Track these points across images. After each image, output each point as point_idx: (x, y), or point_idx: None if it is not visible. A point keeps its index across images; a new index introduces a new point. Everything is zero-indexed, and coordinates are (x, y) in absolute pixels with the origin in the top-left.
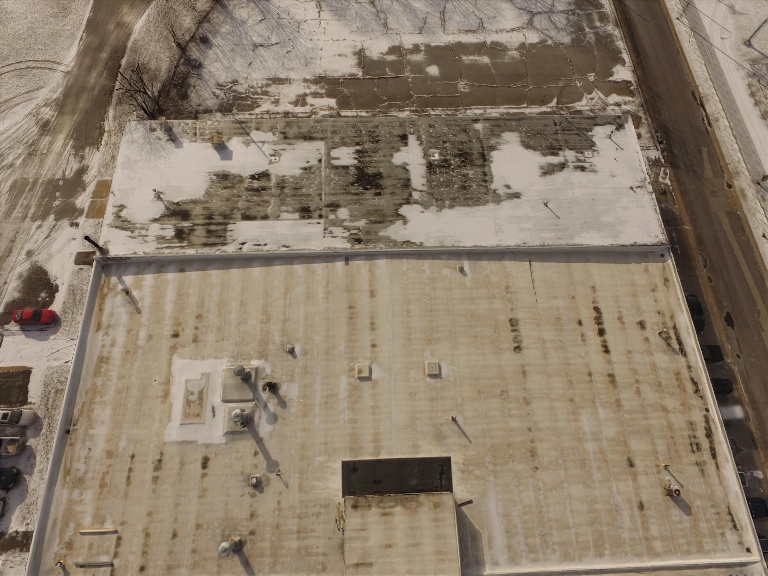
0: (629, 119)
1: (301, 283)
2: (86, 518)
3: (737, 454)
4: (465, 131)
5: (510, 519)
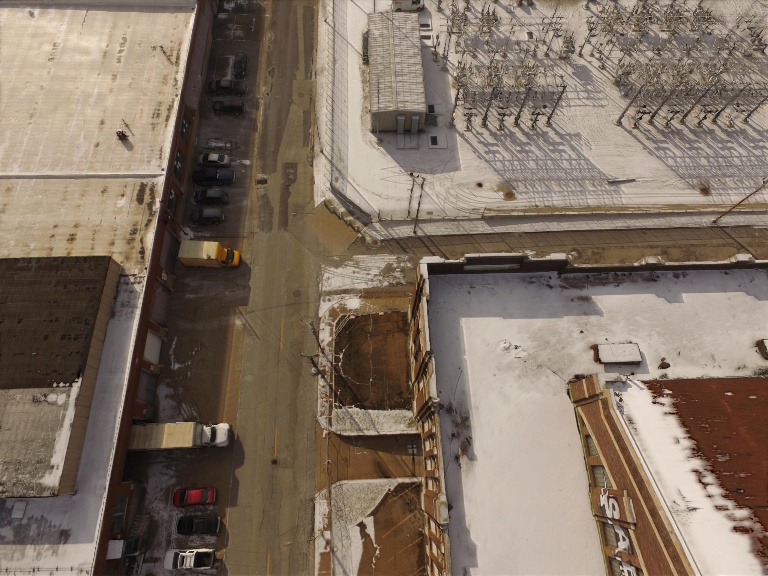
0: None
1: None
2: None
3: (235, 150)
4: None
5: None
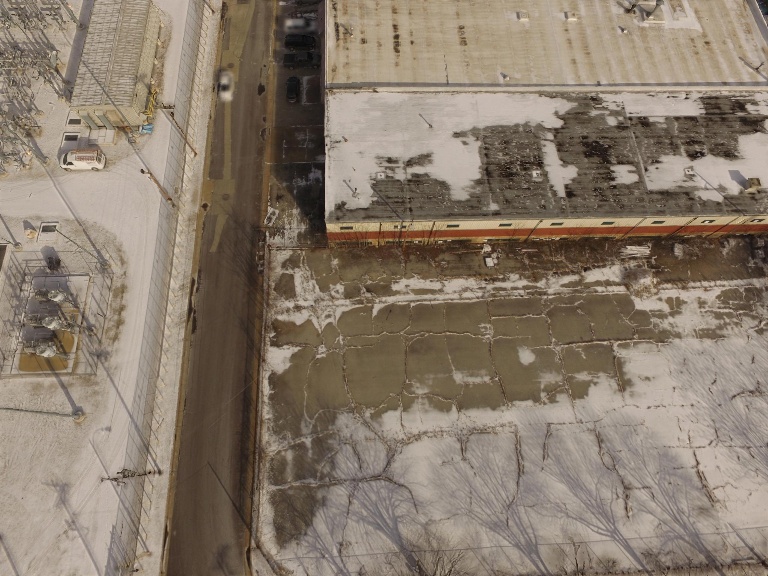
0: (328, 216)
1: (630, 71)
2: None
3: (293, 12)
4: (508, 201)
5: None
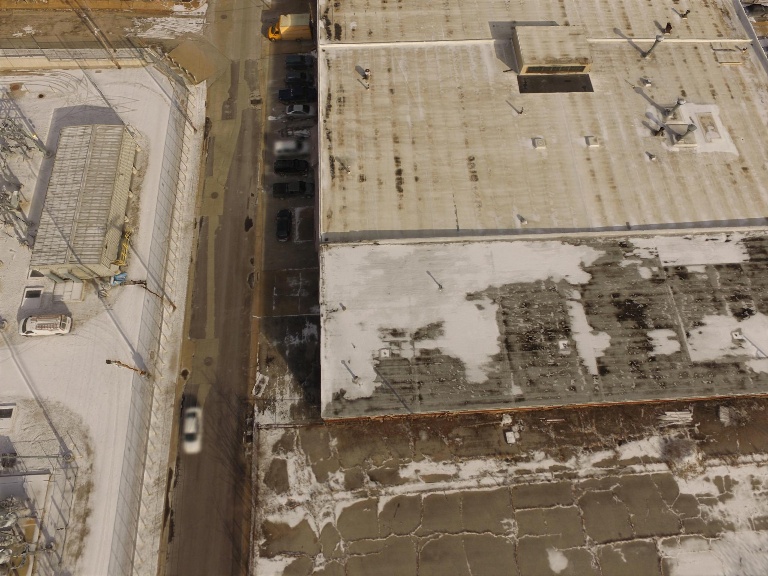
0: (324, 409)
1: (662, 207)
2: (742, 70)
3: (283, 129)
4: (532, 382)
5: (478, 64)
